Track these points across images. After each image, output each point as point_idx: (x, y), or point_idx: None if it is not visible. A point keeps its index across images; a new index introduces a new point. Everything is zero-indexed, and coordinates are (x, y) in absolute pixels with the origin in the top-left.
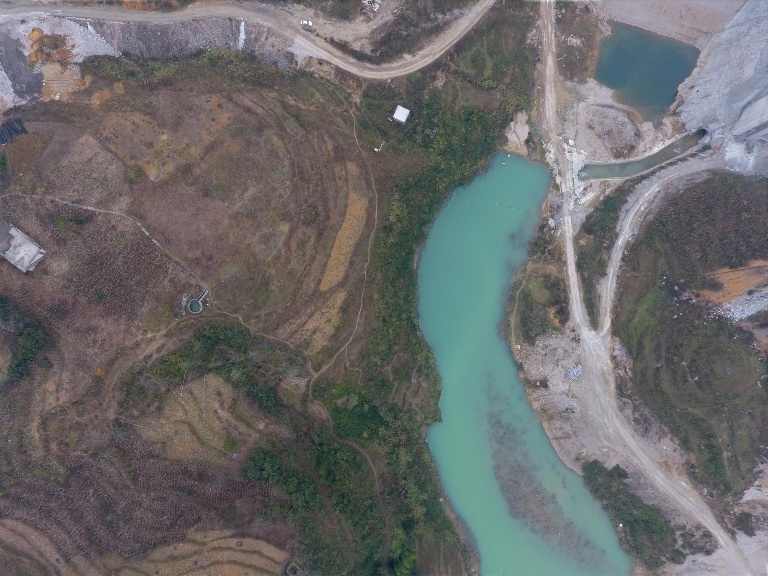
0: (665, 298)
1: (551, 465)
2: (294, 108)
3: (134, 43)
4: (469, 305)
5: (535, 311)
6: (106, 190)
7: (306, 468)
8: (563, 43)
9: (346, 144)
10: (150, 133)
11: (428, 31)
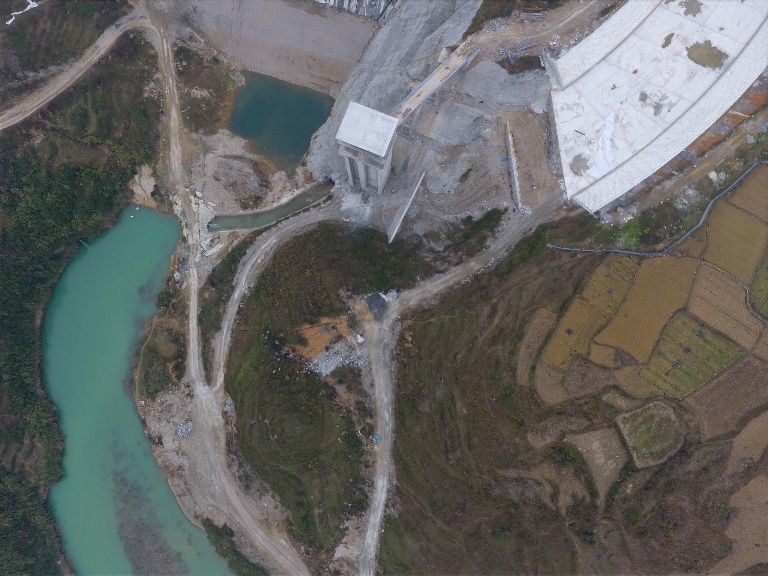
0: (268, 353)
1: (176, 522)
2: None
3: None
4: (100, 360)
5: (154, 366)
6: None
7: None
8: (186, 95)
9: None
10: None
11: (15, 90)
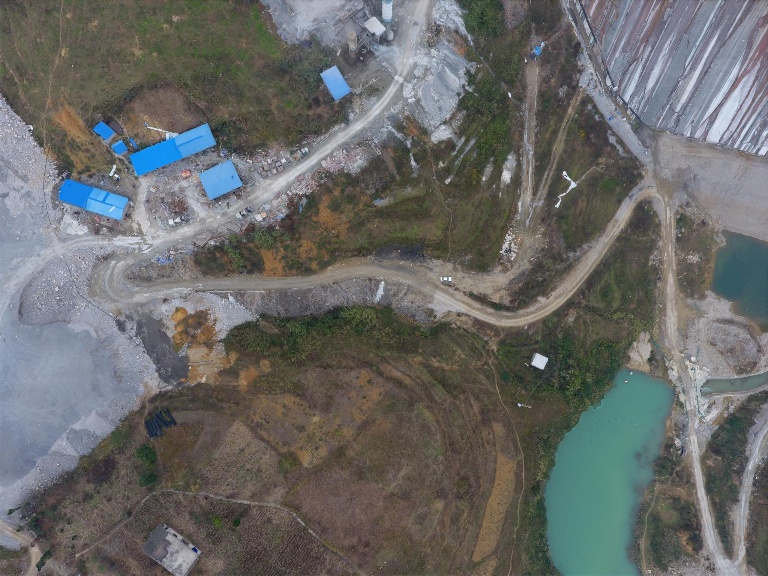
0: None
1: None
2: (439, 371)
3: (273, 307)
4: (595, 525)
5: (667, 538)
6: (260, 482)
7: None
8: (683, 261)
9: (491, 404)
10: (301, 416)
11: (561, 272)
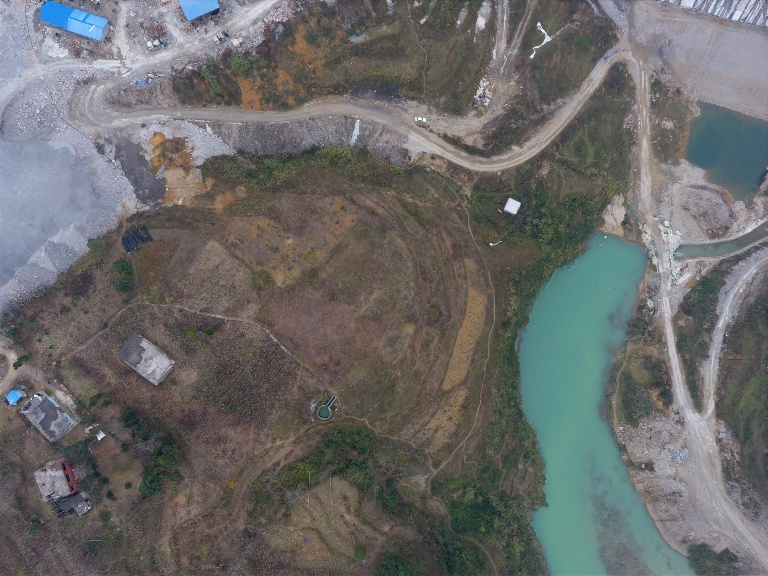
0: None
1: (656, 547)
2: (412, 206)
3: (250, 142)
4: (569, 386)
5: (638, 393)
6: (234, 297)
7: (435, 572)
8: (657, 126)
9: (463, 240)
10: (275, 238)
11: (535, 122)
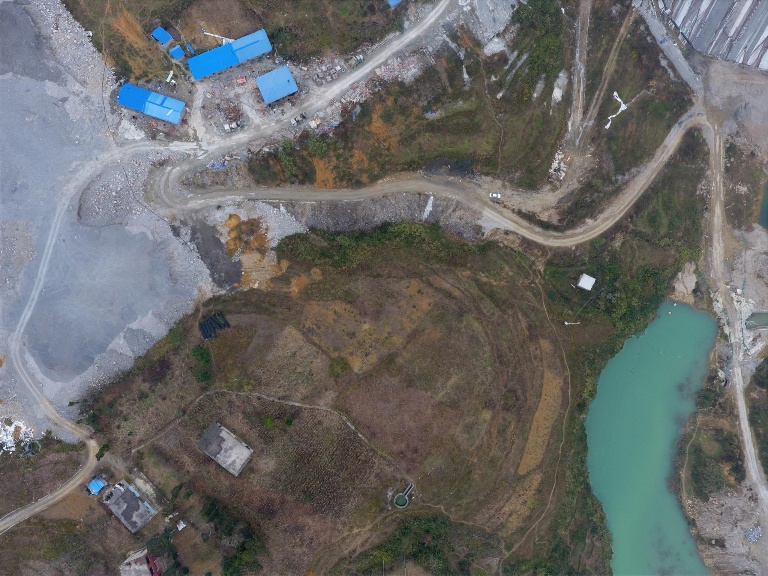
0: None
1: None
2: (487, 286)
3: (322, 219)
4: (635, 456)
5: (709, 468)
6: (312, 385)
7: None
8: (731, 191)
9: (539, 320)
10: (352, 322)
11: (609, 194)
